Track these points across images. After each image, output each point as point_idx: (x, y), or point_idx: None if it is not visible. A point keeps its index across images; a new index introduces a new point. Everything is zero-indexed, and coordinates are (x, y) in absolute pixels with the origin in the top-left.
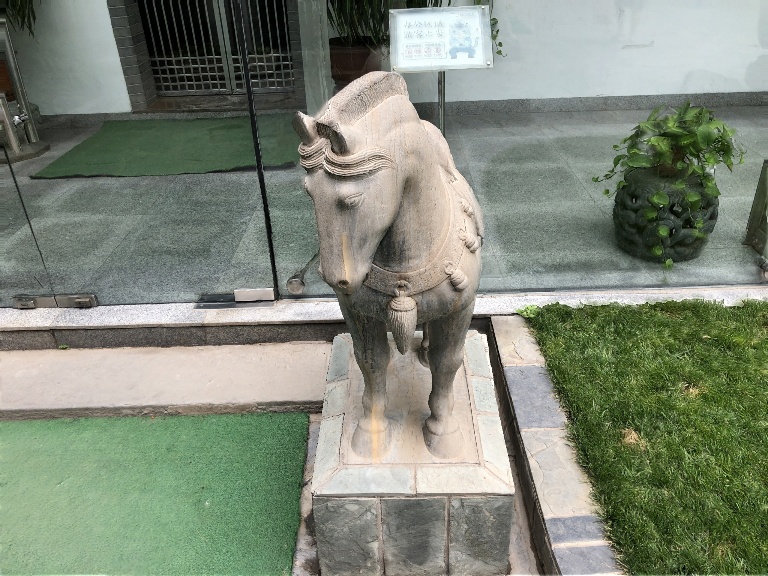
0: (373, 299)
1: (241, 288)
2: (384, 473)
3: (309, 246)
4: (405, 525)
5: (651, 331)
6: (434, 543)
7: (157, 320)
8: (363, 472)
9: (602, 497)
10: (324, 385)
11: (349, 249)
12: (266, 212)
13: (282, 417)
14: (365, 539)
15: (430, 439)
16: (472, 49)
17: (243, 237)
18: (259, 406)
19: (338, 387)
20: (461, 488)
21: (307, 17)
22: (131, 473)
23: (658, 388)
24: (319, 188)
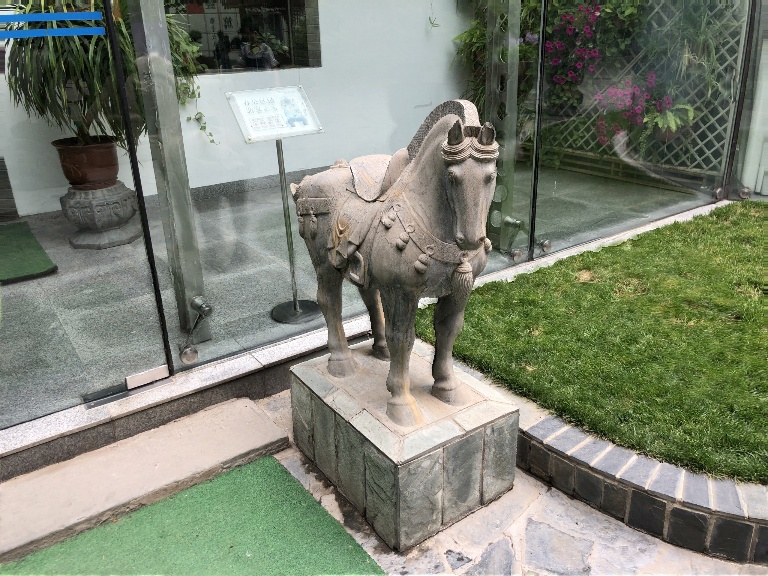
0: (443, 271)
1: (132, 374)
2: (435, 429)
3: (154, 328)
4: (458, 466)
5: (481, 308)
6: (474, 476)
7: (54, 431)
8: (421, 434)
9: (545, 404)
10: (272, 427)
11: (485, 213)
12: (157, 286)
13: (251, 467)
14: (434, 492)
15: (447, 396)
16: (304, 118)
17: (70, 339)
18: (225, 465)
19: (338, 396)
20: (490, 417)
21: (164, 99)
22: (142, 572)
23: (516, 337)
24: (468, 171)
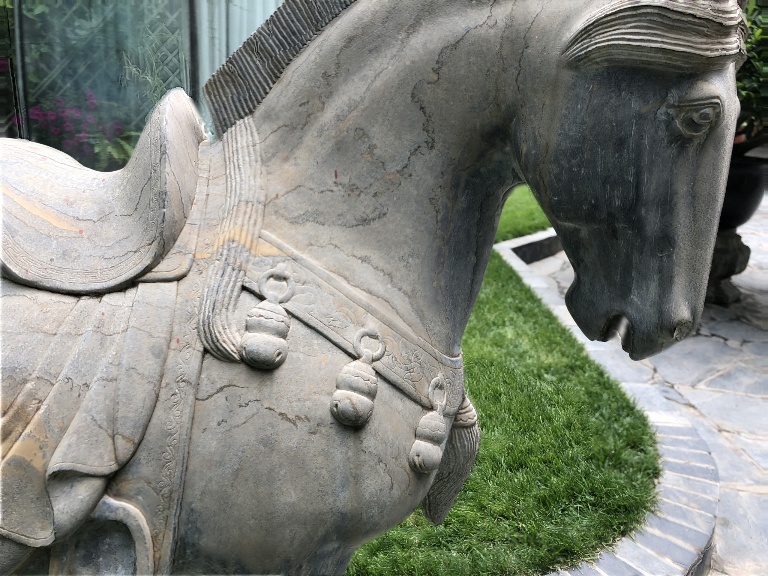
0: None
1: None
2: None
3: None
4: None
5: None
6: None
7: None
8: None
9: None
10: None
11: None
12: None
13: None
14: None
15: None
16: None
17: None
18: None
19: None
20: None
21: None
22: None
23: None
24: None
